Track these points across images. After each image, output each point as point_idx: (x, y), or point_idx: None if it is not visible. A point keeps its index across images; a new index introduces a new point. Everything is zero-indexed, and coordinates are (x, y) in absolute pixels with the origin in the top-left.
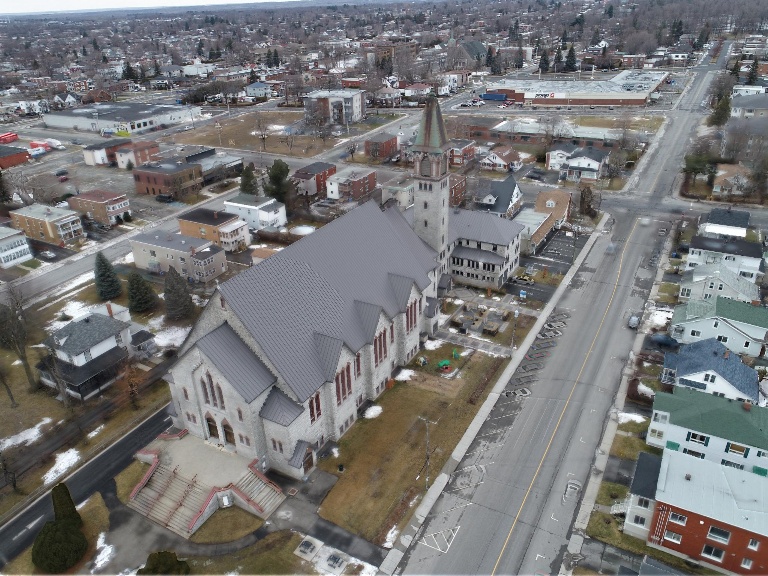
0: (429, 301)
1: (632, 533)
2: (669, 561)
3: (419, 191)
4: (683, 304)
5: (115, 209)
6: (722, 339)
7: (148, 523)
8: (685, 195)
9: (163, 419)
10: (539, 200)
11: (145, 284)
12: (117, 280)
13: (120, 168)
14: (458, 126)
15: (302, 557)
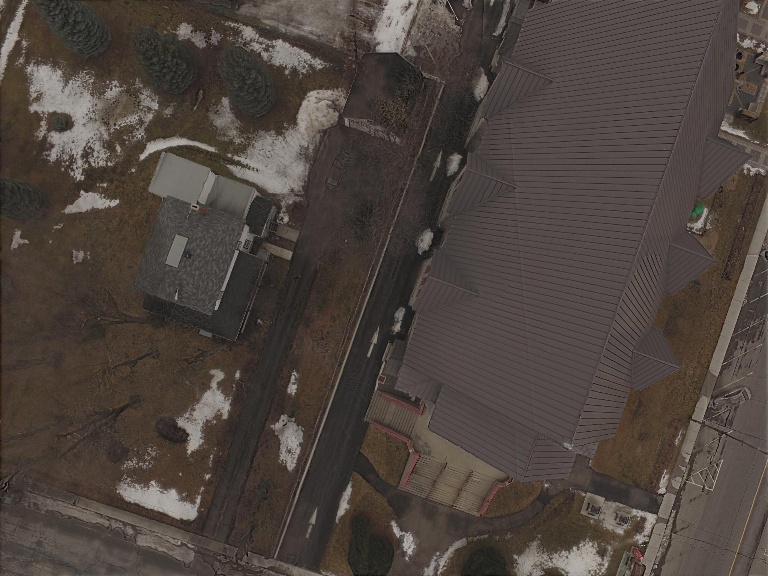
0: None
1: None
2: None
3: None
4: None
5: None
6: None
7: (431, 504)
8: None
9: (365, 354)
10: None
11: (165, 44)
12: (92, 19)
13: None
14: None
15: (590, 517)
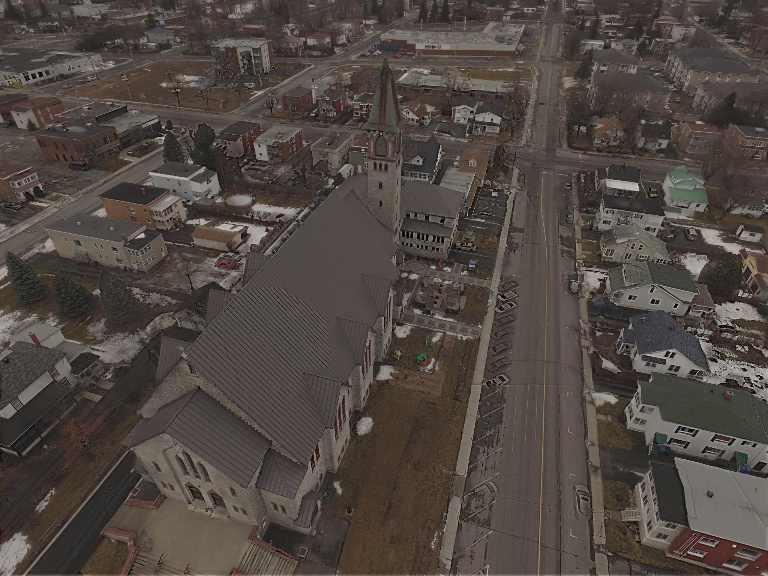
0: (396, 289)
1: (651, 545)
2: (691, 572)
3: (373, 171)
4: (616, 268)
5: (21, 185)
6: (655, 302)
7: None
8: (573, 147)
9: (129, 470)
10: (462, 159)
11: (75, 286)
12: (39, 281)
13: (20, 128)
14: (369, 80)
15: None
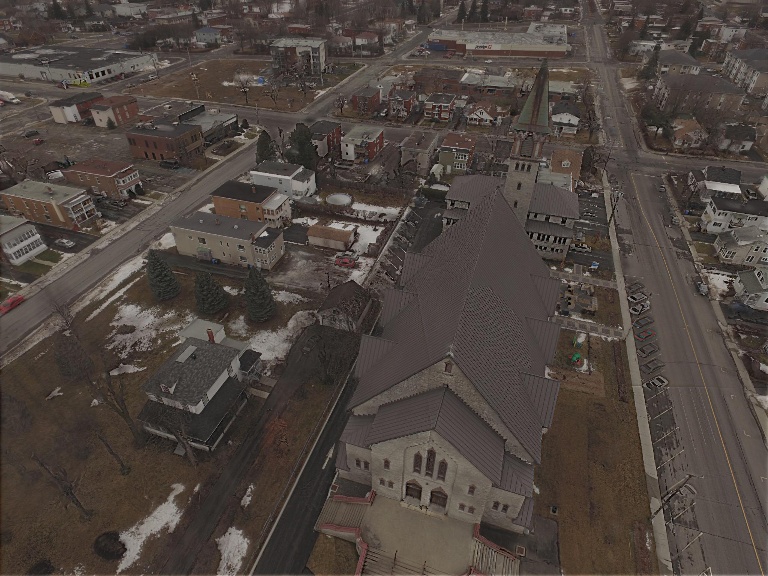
0: None
1: None
2: None
3: (514, 172)
4: (746, 271)
5: (125, 182)
6: None
7: None
8: (654, 148)
9: (320, 466)
10: (554, 160)
11: (214, 283)
12: (174, 278)
13: (98, 127)
14: (437, 80)
15: None
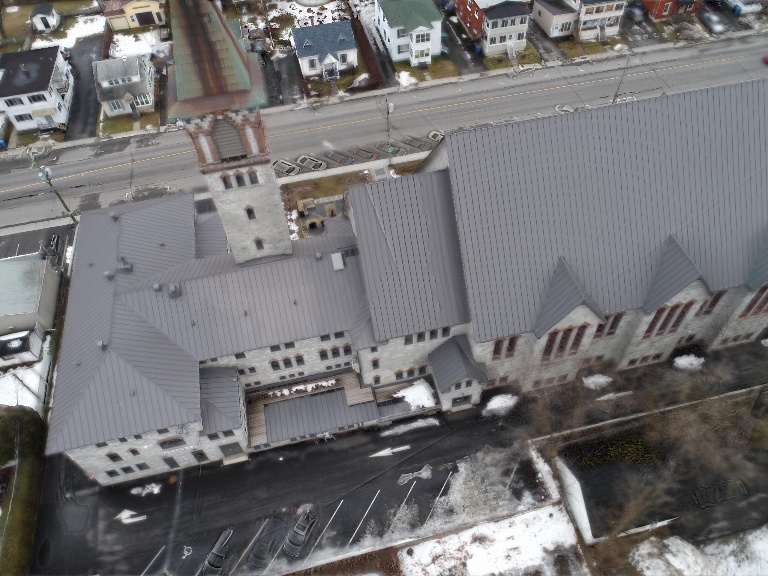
0: None
1: None
2: None
3: None
4: None
5: None
6: None
7: None
8: None
9: None
10: None
11: None
12: None
13: None
14: None
15: None
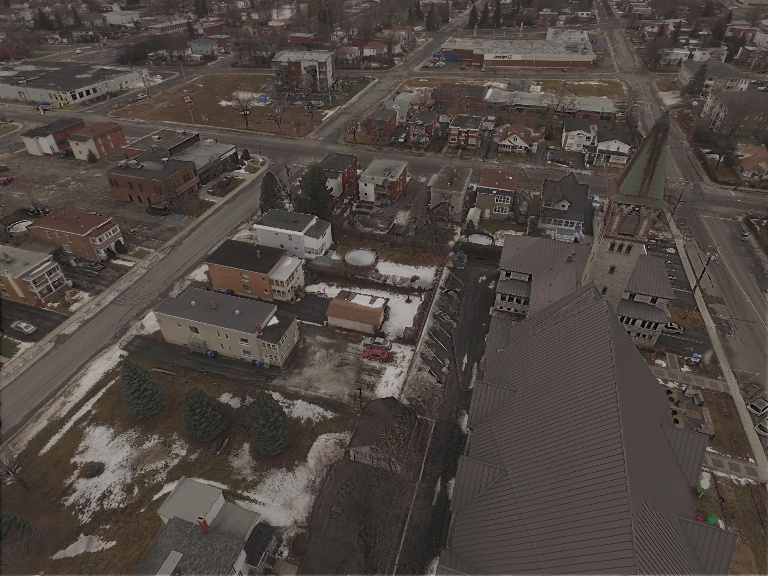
0: None
1: None
2: None
3: (607, 253)
4: None
5: (103, 240)
6: None
7: None
8: (719, 181)
9: None
10: None
11: (209, 401)
12: (157, 389)
13: (78, 159)
14: (461, 100)
15: None
